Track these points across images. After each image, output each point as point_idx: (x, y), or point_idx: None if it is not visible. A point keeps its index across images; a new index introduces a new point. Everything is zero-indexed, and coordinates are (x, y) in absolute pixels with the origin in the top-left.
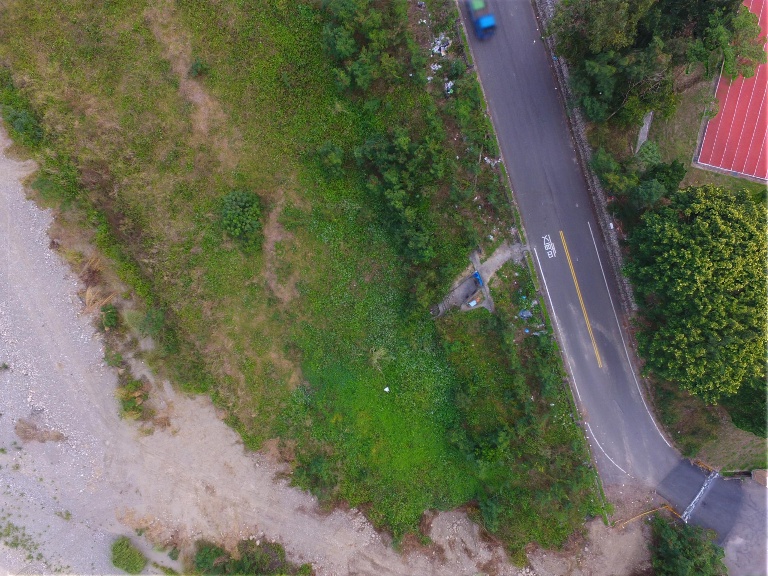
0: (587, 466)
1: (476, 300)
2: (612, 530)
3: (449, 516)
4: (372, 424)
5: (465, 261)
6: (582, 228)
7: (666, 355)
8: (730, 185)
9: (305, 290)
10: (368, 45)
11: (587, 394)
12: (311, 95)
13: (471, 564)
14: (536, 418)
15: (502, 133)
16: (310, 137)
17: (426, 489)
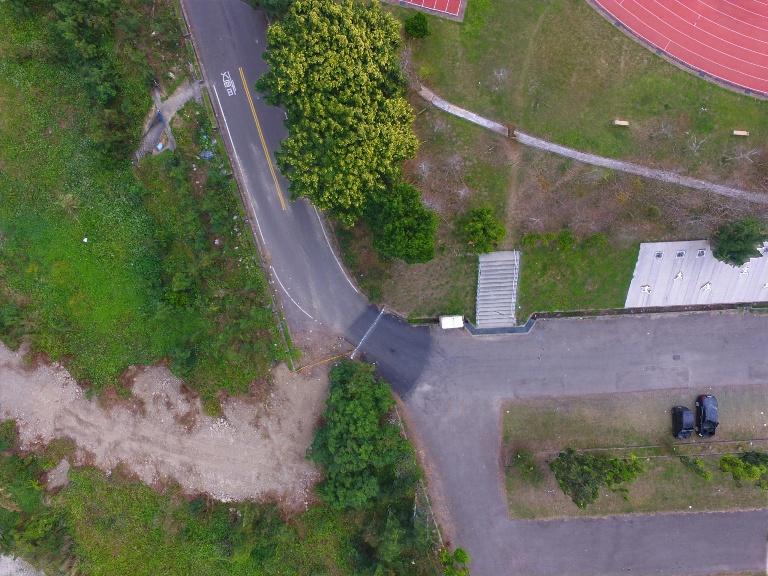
0: (271, 310)
1: (162, 142)
2: (297, 375)
3: (160, 374)
4: (71, 275)
5: (146, 100)
6: (262, 65)
7: (293, 169)
8: (398, 15)
9: None
10: None
11: (271, 237)
12: None
13: (167, 415)
14: (203, 254)
15: None
16: None
17: (125, 341)
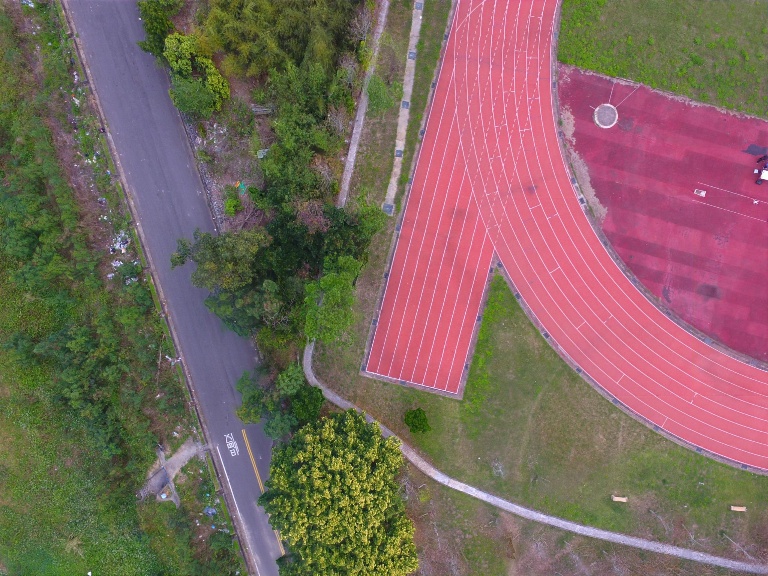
0: None
1: (166, 493)
2: None
3: None
4: None
5: (150, 457)
6: None
7: None
8: (398, 394)
9: (3, 476)
10: (41, 245)
11: None
12: (5, 282)
13: None
14: None
15: (181, 332)
16: (7, 322)
17: None
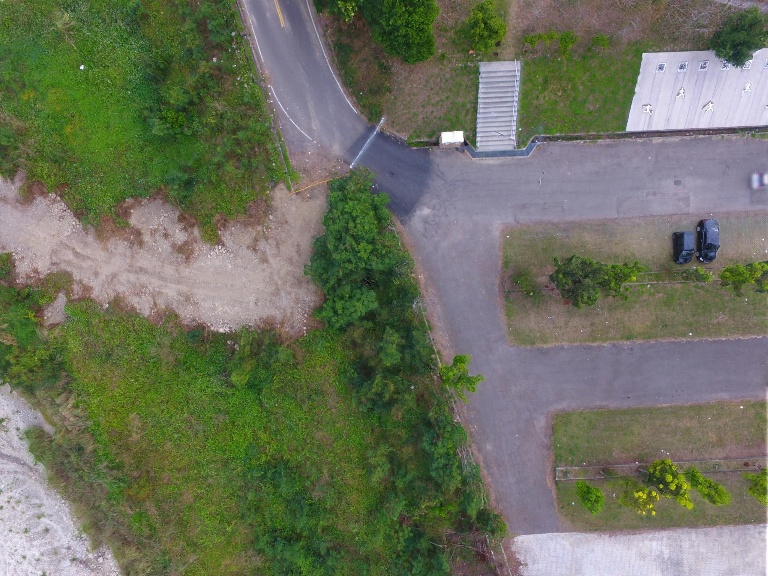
0: (269, 129)
1: None
2: (296, 196)
3: (157, 210)
4: (67, 103)
5: None
6: None
7: None
8: None
9: None
10: None
11: (269, 54)
12: None
13: (165, 243)
14: (201, 62)
15: None
16: None
17: (122, 170)
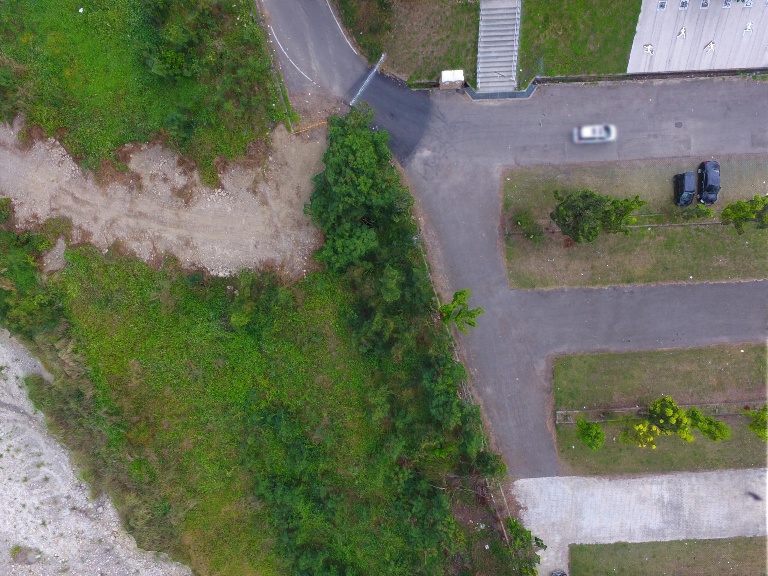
0: (269, 69)
1: None
2: (295, 138)
3: (157, 156)
4: (66, 47)
5: None
6: None
7: None
8: None
9: None
10: None
11: None
12: None
13: (164, 187)
14: None
15: None
16: None
17: (122, 114)
